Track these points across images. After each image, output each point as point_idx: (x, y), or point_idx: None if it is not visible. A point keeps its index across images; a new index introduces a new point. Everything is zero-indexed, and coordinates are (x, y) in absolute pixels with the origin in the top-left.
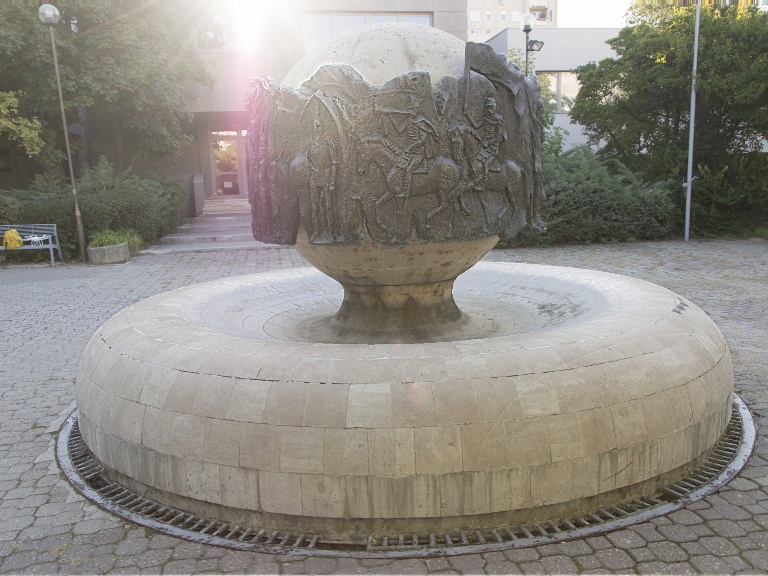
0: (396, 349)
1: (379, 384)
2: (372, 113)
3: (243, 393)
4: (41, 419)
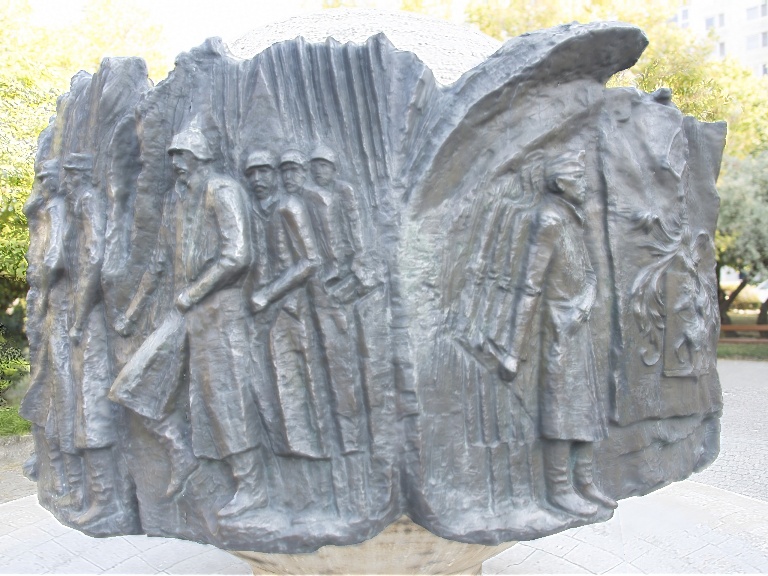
0: None
1: None
2: None
3: None
4: None
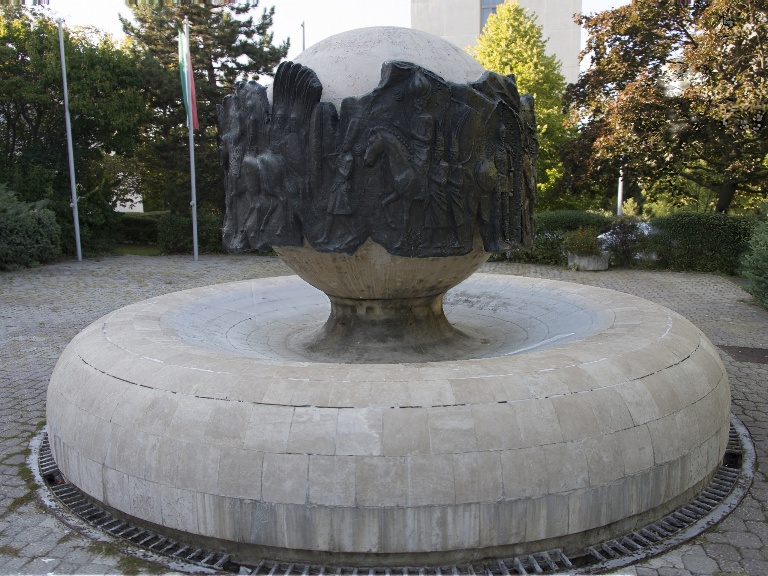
0: None
1: (701, 339)
2: None
3: (692, 373)
4: None
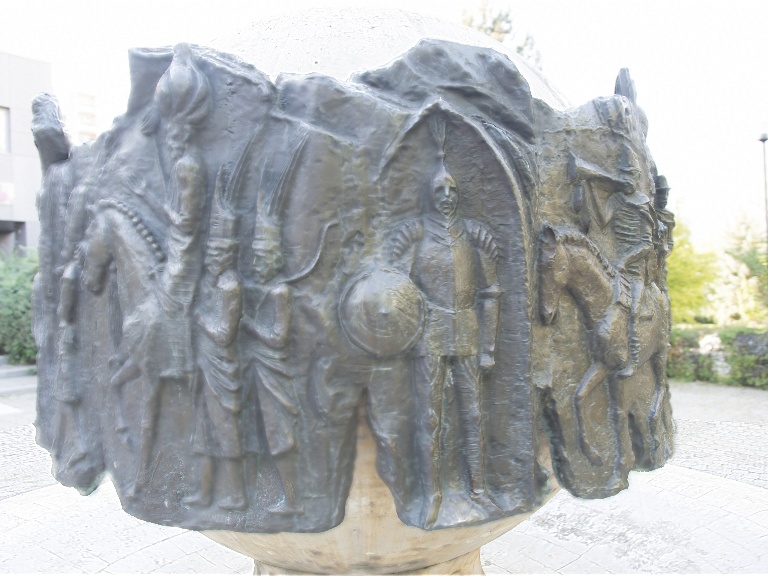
0: None
1: None
2: (564, 171)
3: None
4: None
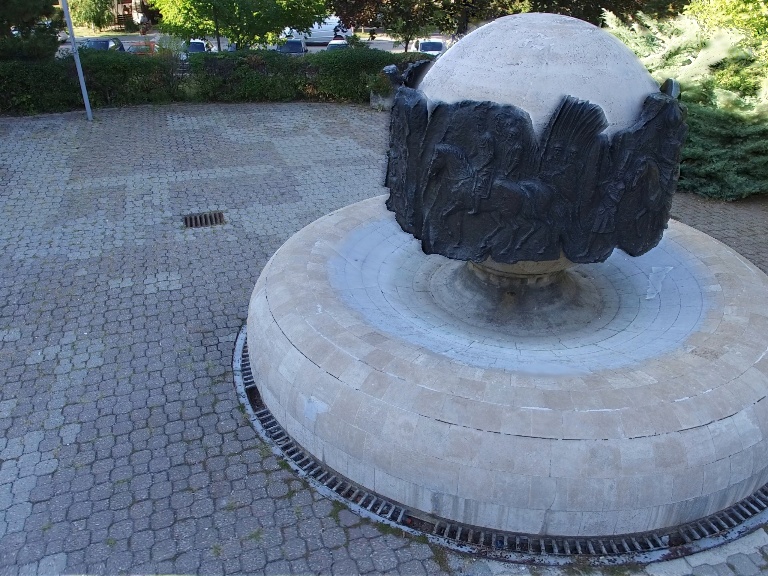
0: (713, 249)
1: None
2: None
3: None
4: (749, 573)
